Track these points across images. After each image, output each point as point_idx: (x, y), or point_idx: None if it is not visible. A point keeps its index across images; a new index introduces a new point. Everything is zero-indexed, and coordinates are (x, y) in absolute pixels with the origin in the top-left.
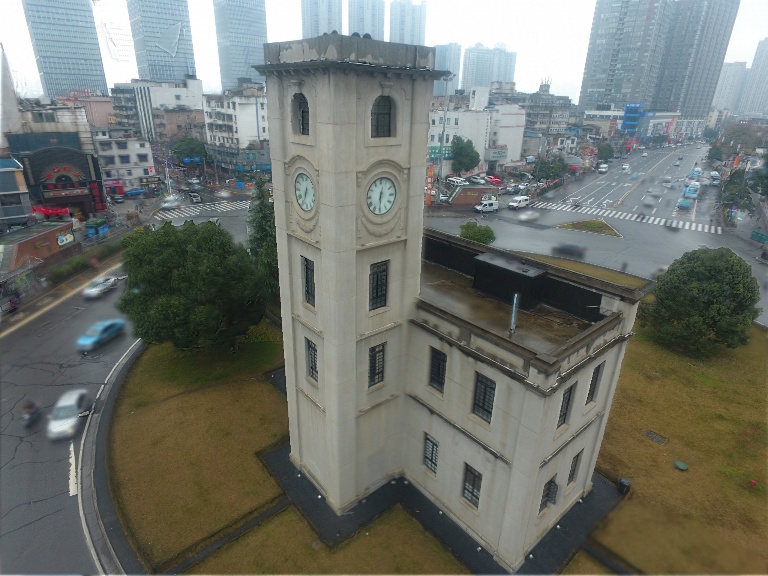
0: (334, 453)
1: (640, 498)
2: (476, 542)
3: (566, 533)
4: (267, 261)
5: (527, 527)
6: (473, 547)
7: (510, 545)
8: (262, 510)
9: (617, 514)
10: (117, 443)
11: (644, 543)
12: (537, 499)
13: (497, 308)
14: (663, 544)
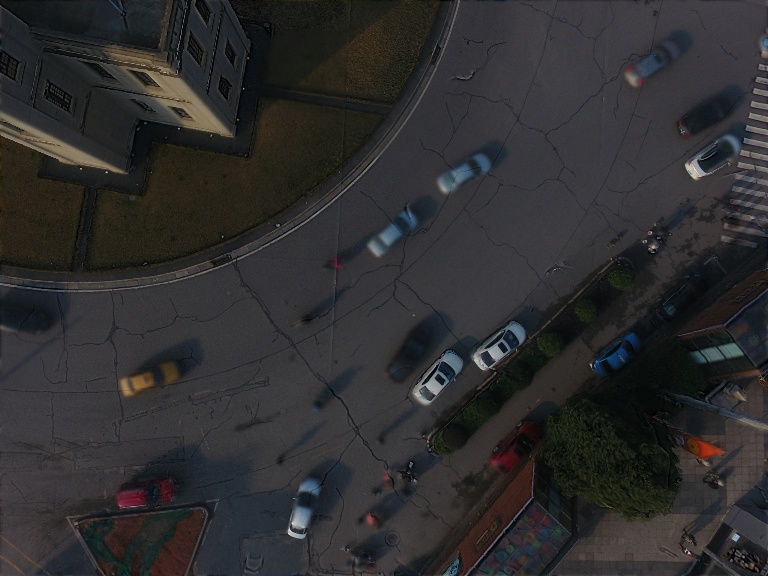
0: None
1: (279, 30)
2: (208, 132)
3: (249, 90)
4: None
5: (225, 115)
6: (208, 137)
7: (223, 129)
8: (85, 205)
9: (270, 54)
10: None
11: (289, 67)
12: (220, 99)
13: None
14: (298, 60)
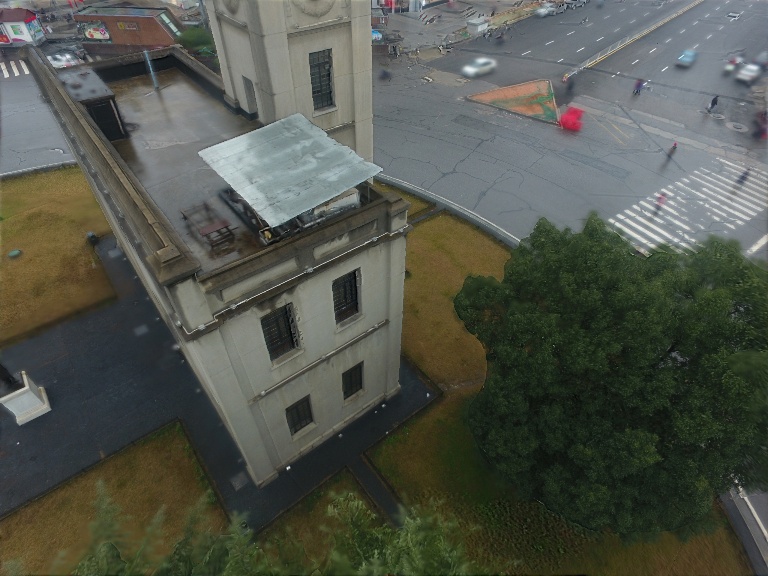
0: None
1: None
2: None
3: None
4: None
5: None
6: None
7: None
8: None
9: None
10: None
11: None
12: None
13: (137, 111)
14: None
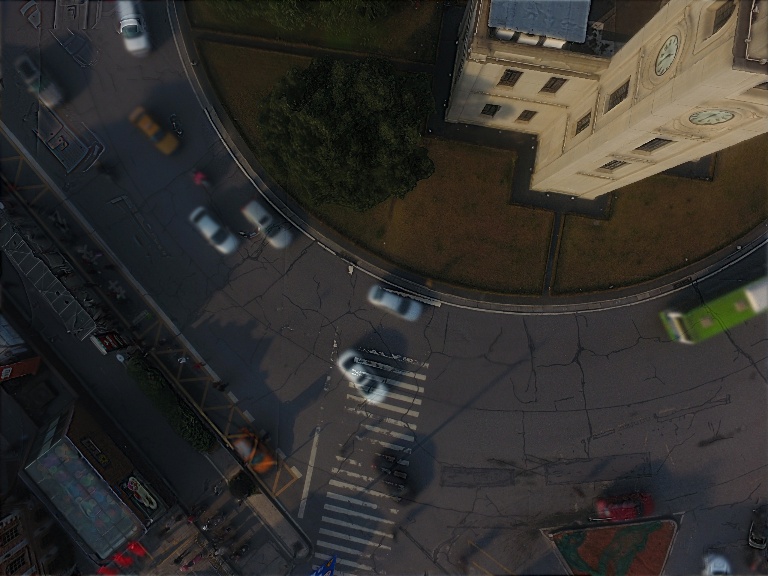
0: (612, 188)
1: None
2: None
3: None
4: (296, 1)
5: None
6: None
7: None
8: (553, 230)
9: None
10: (414, 267)
11: None
12: None
13: None
14: None
